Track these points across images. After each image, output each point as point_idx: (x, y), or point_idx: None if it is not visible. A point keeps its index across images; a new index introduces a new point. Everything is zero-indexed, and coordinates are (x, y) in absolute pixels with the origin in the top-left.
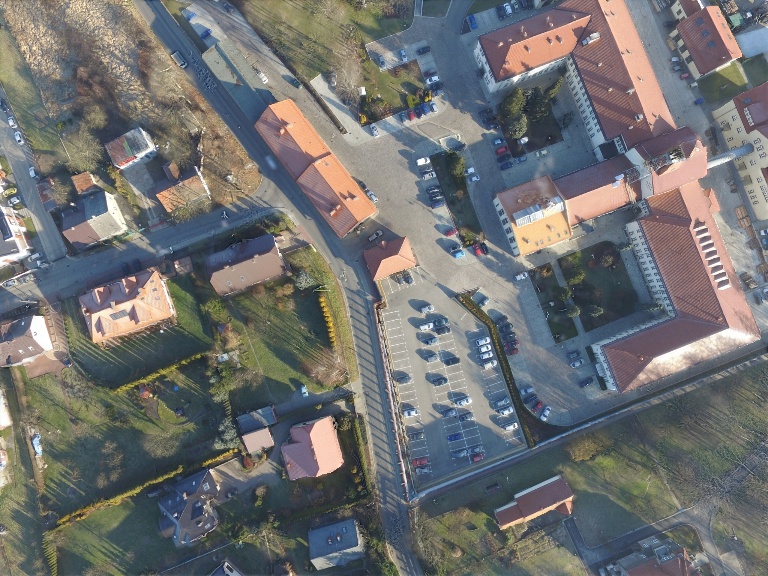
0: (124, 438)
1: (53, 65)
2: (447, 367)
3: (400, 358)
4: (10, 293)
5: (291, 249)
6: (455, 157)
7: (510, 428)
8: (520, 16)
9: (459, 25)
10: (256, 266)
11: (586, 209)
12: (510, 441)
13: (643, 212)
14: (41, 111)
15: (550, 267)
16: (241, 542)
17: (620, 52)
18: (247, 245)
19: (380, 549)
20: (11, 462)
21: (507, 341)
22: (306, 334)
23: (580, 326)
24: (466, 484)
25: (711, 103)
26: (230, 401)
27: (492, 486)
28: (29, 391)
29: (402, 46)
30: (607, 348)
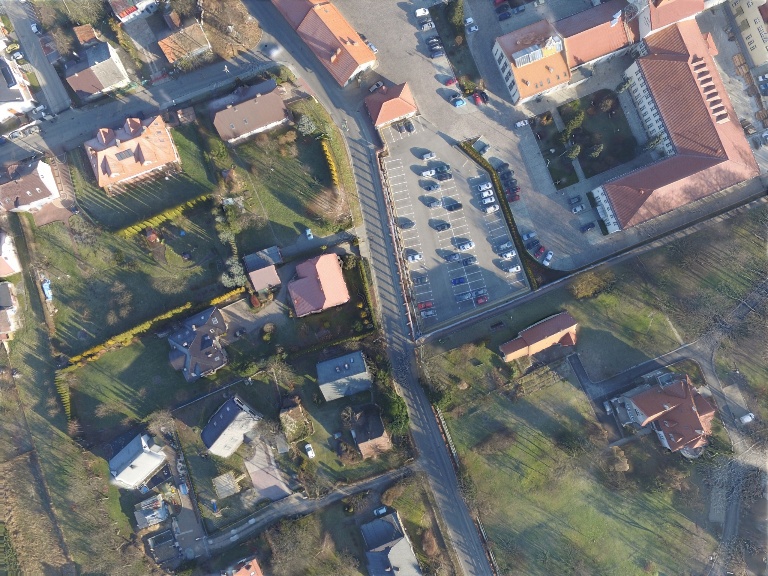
0: (132, 282)
1: None
2: (450, 213)
3: (403, 205)
4: (16, 145)
5: (293, 100)
6: (453, 3)
7: (513, 270)
8: None
9: None
10: (259, 107)
11: (585, 50)
12: (513, 284)
13: (641, 55)
14: None
15: (550, 115)
16: (250, 379)
17: None
18: (249, 90)
19: (387, 384)
20: (22, 308)
21: (509, 188)
22: (310, 180)
23: (581, 173)
24: (471, 325)
25: None
26: (236, 244)
27: (496, 325)
28: (37, 238)
29: None
30: (608, 185)
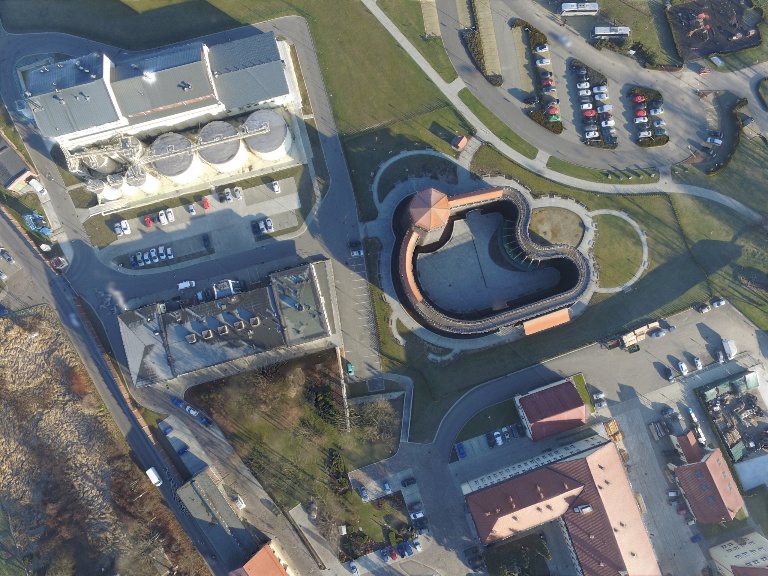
0: None
1: (23, 487)
2: None
3: None
4: None
5: None
6: None
7: None
8: (511, 443)
9: (447, 453)
10: None
11: None
12: None
13: None
14: (8, 540)
15: None
16: None
17: (613, 531)
18: None
19: None
20: None
21: None
22: None
23: None
24: None
25: (709, 539)
26: None
27: None
28: None
29: (386, 475)
30: None
